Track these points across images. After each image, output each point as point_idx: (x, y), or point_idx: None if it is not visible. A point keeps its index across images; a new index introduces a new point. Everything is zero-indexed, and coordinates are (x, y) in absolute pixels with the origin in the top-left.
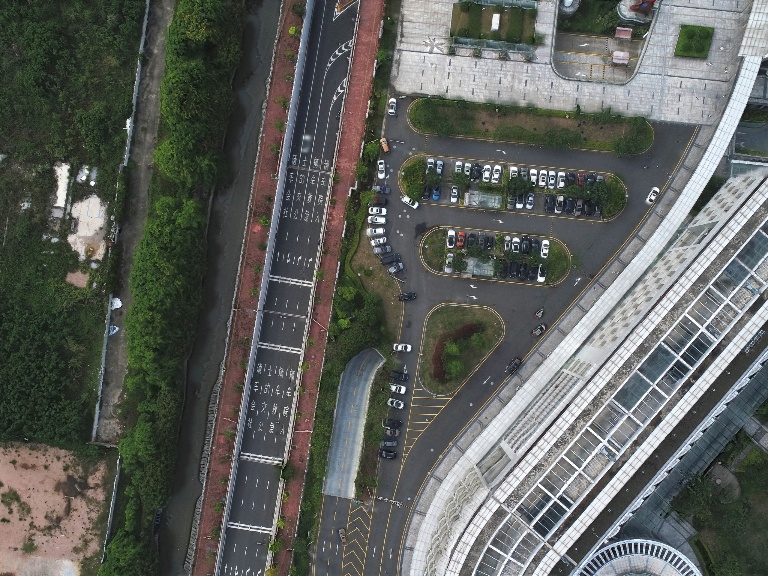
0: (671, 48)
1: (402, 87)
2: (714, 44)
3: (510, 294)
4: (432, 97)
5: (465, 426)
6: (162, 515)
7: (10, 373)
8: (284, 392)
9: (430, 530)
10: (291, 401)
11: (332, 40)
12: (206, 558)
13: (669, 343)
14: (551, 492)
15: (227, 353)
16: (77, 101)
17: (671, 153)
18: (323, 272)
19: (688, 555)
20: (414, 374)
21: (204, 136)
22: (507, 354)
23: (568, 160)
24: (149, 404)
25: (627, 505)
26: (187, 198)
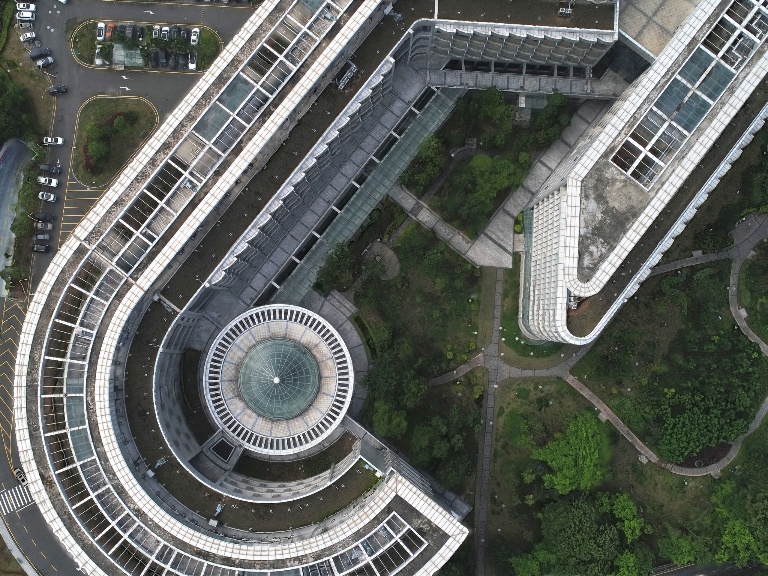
0: None
1: None
2: None
3: (163, 83)
4: None
5: None
6: None
7: None
8: None
9: None
10: None
11: None
12: None
13: (247, 72)
14: (133, 227)
15: None
16: None
17: None
18: None
19: (350, 333)
20: (67, 168)
21: None
22: None
23: None
24: None
25: (229, 248)
26: None
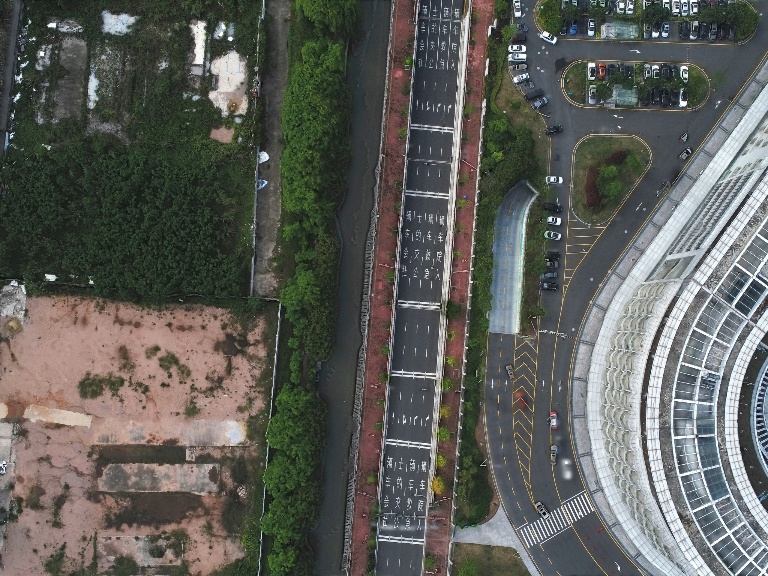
0: None
1: None
2: None
3: (654, 121)
4: None
5: (622, 253)
6: (321, 372)
7: (165, 228)
8: (436, 237)
9: (604, 351)
10: (443, 246)
11: None
12: (374, 407)
13: None
14: (749, 270)
15: (379, 199)
16: None
17: None
18: (468, 112)
19: None
20: (567, 206)
21: None
22: (657, 179)
23: None
24: (307, 252)
25: None
26: None
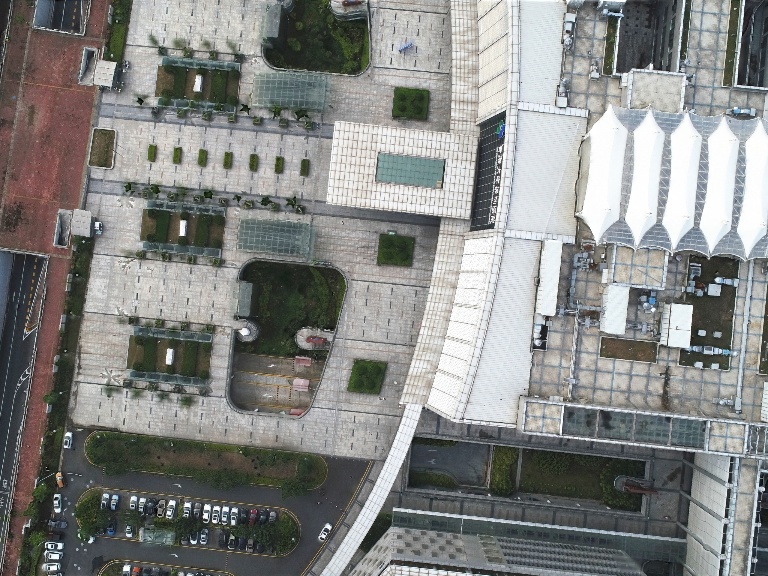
0: (345, 382)
1: (79, 419)
2: (388, 378)
3: None
4: (109, 430)
5: None
6: None
7: None
8: None
9: None
10: None
11: (22, 360)
12: None
13: None
14: None
15: None
16: None
17: (344, 489)
18: None
19: None
20: None
21: None
22: None
23: (242, 495)
24: None
25: None
26: None
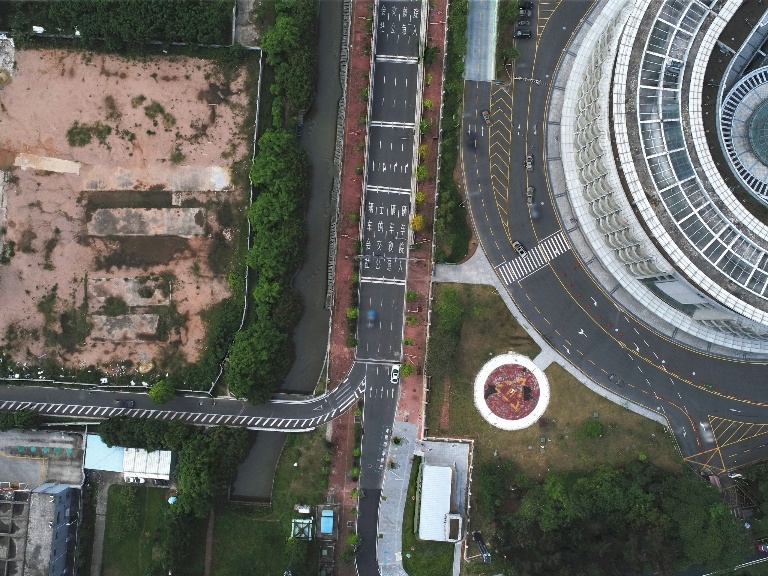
0: None
1: None
2: None
3: None
4: None
5: (593, 3)
6: (303, 127)
7: None
8: None
9: (576, 86)
10: (420, 3)
11: None
12: (354, 153)
13: None
14: None
15: None
16: None
17: None
18: None
19: None
20: None
21: None
22: None
23: None
24: (287, 1)
25: None
26: None
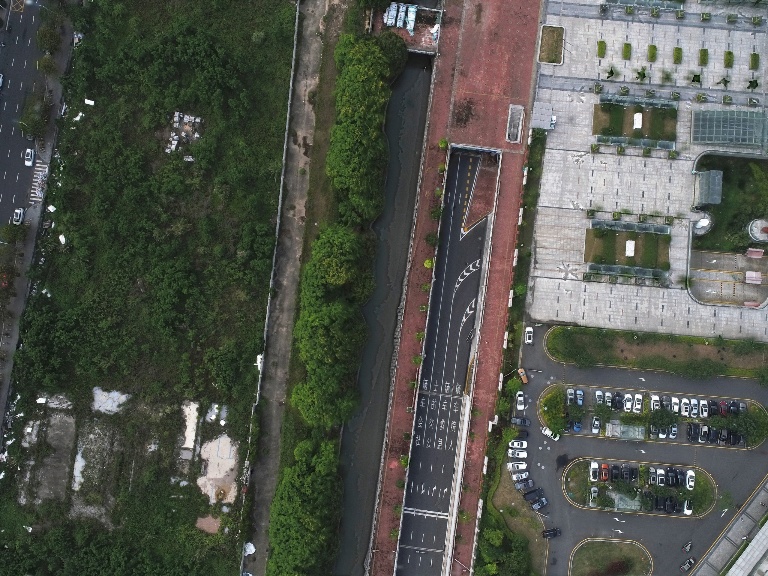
0: None
1: (538, 314)
2: None
3: (656, 527)
4: (568, 324)
5: None
6: None
7: None
8: None
9: None
10: None
11: (459, 260)
12: None
13: None
14: None
15: None
16: (206, 339)
17: None
18: (463, 509)
19: None
20: None
21: (342, 377)
22: None
23: (709, 387)
24: None
25: None
26: (323, 438)
